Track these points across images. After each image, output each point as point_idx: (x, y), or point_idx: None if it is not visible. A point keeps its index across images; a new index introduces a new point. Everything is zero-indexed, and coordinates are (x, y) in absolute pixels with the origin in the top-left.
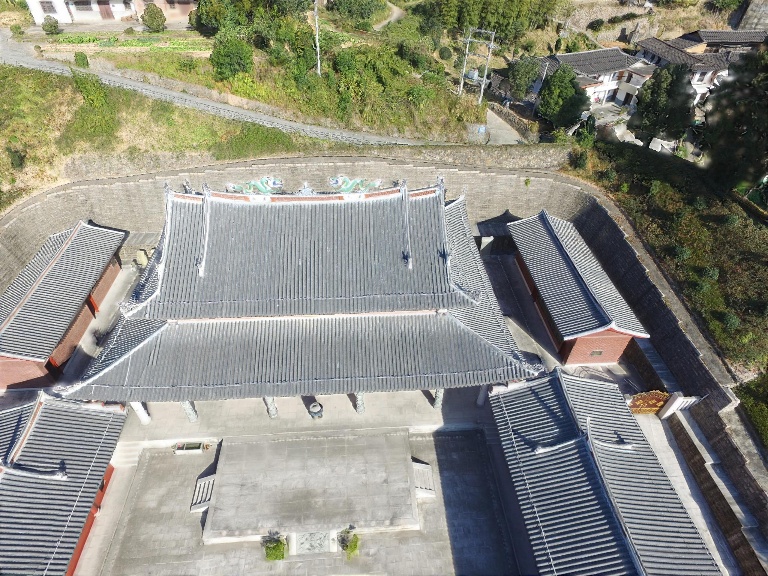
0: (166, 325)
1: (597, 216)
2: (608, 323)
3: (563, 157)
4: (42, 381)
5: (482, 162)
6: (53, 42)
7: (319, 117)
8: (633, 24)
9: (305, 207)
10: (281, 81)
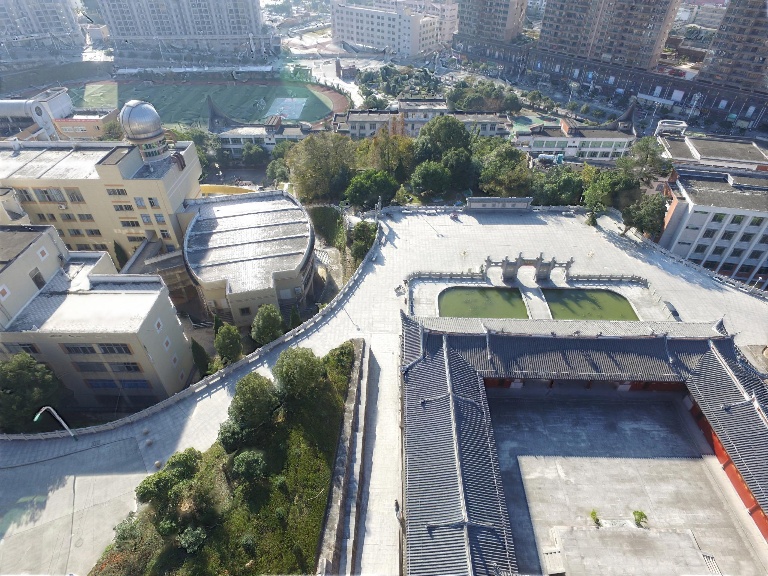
0: None
1: None
2: None
3: None
4: None
5: None
6: None
7: None
8: None
9: None
10: None
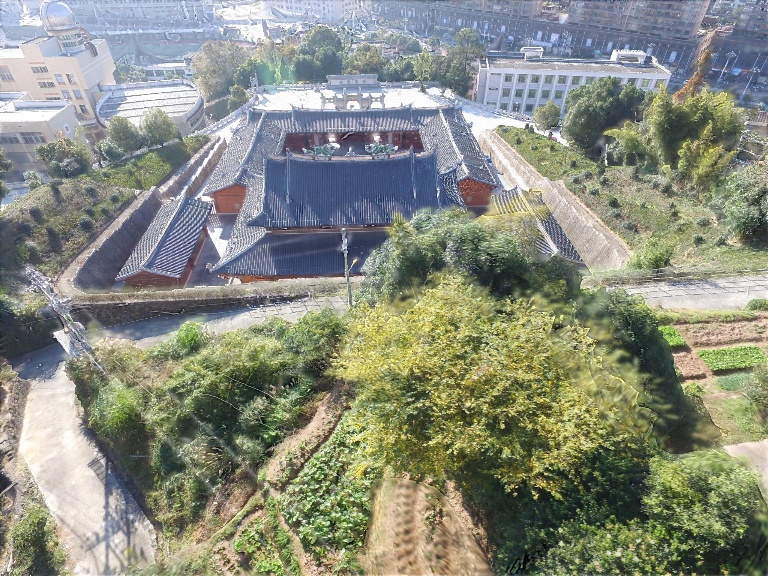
0: None
1: None
2: None
3: None
4: None
5: None
6: None
7: None
8: None
9: None
10: None
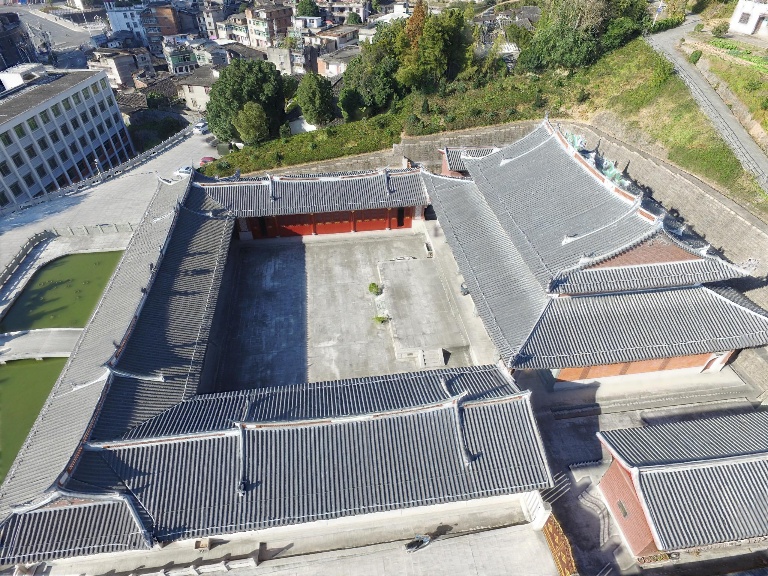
0: None
1: None
2: None
3: None
4: None
5: None
6: (706, 42)
7: None
8: None
9: (583, 172)
10: None
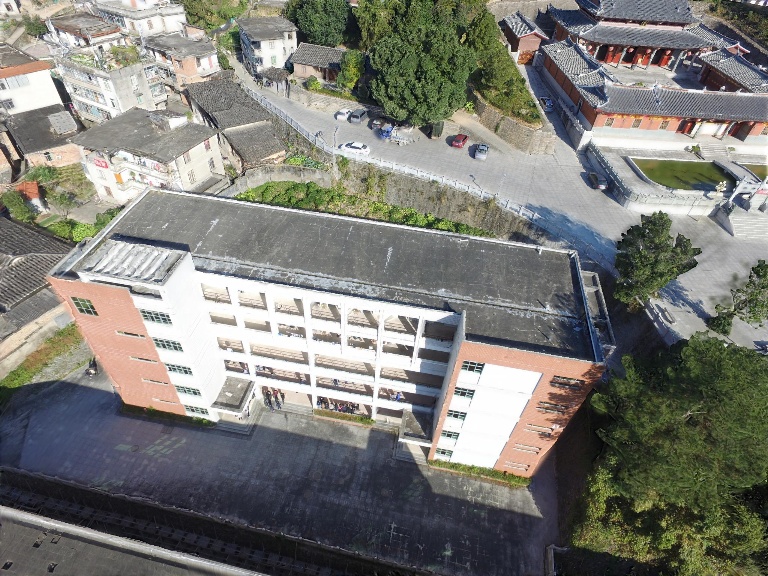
0: (597, 25)
1: (722, 30)
2: (737, 43)
3: (707, 7)
4: None
5: None
6: None
7: None
8: None
9: None
10: None
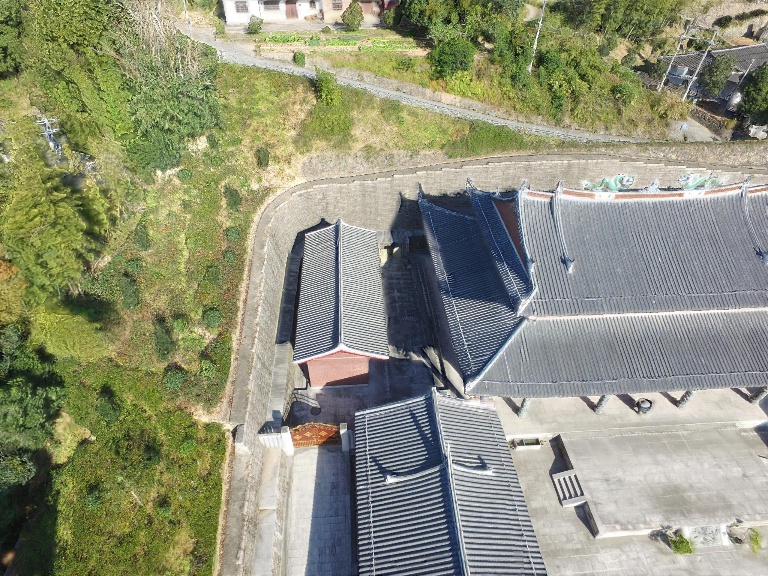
0: (525, 322)
1: None
2: None
3: None
4: (362, 378)
5: (704, 159)
6: (259, 41)
7: (531, 115)
8: (761, 20)
9: (646, 204)
10: (497, 79)
